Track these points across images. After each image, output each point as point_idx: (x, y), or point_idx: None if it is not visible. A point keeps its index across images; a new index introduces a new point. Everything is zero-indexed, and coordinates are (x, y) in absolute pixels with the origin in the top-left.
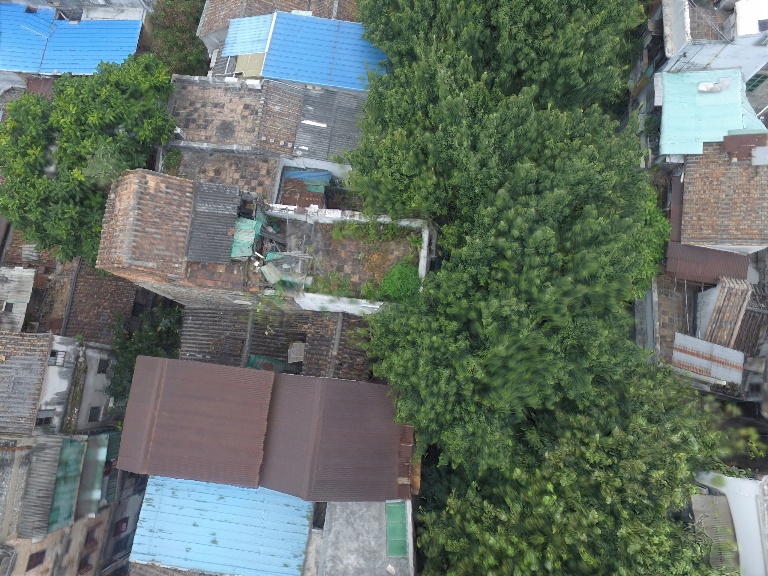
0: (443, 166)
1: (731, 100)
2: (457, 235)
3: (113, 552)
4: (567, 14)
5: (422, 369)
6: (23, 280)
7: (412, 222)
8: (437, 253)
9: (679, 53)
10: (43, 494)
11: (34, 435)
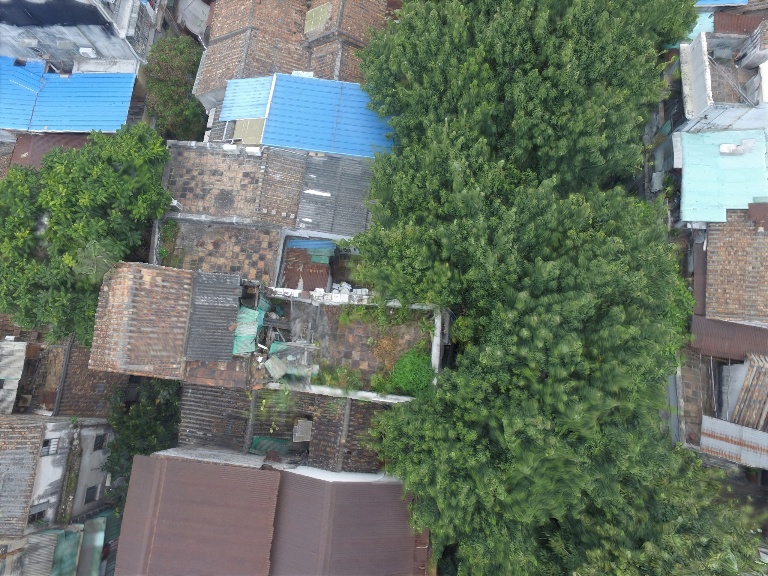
0: (457, 256)
1: (755, 164)
2: (473, 327)
3: None
4: (585, 88)
5: (440, 484)
6: (14, 354)
7: (424, 306)
8: (451, 340)
9: (700, 115)
10: None
11: (26, 534)
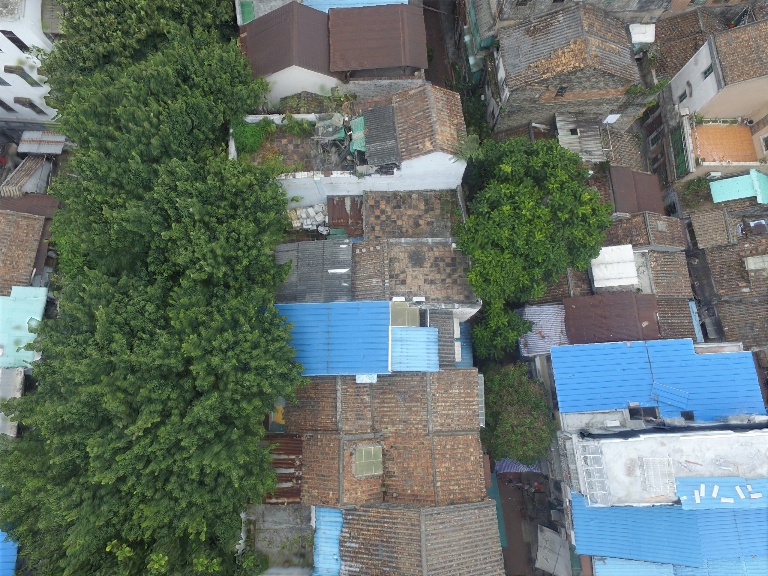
0: None
1: None
2: None
3: None
4: None
5: None
6: None
7: None
8: None
9: None
10: (480, 7)
11: None
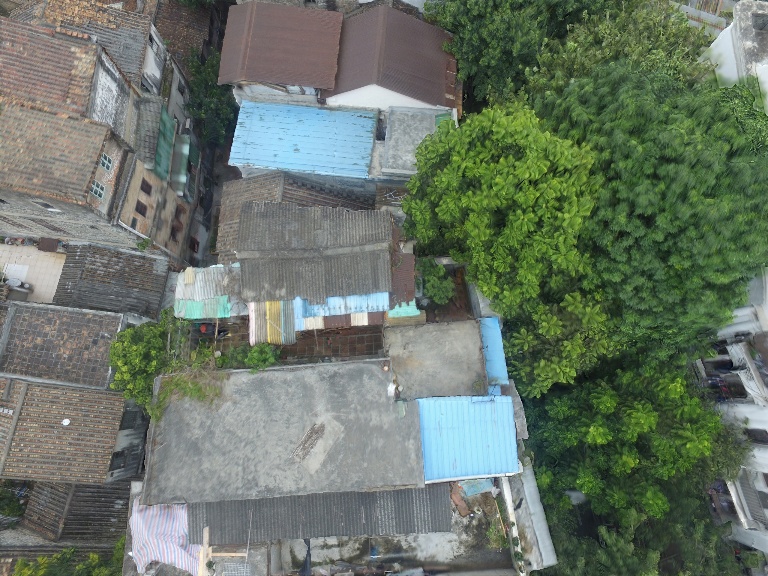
0: None
1: None
2: None
3: (189, 263)
4: None
5: None
6: None
7: None
8: None
9: None
10: (150, 134)
11: None
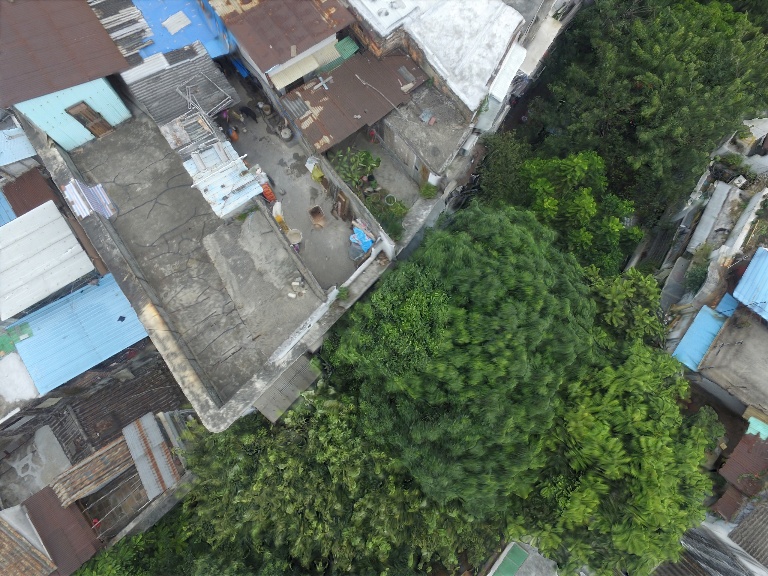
0: None
1: None
2: None
3: None
4: None
5: None
6: None
7: None
8: None
9: None
10: None
11: None
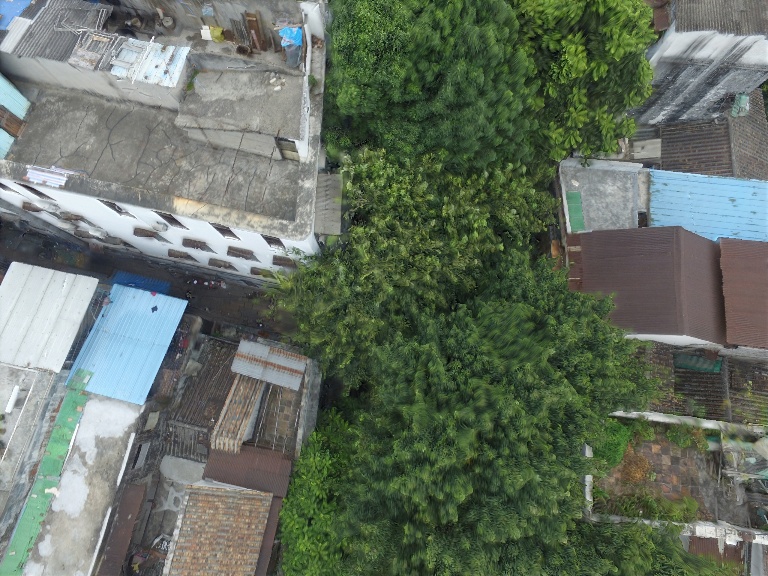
0: None
1: None
2: None
3: None
4: None
5: None
6: None
7: (606, 519)
8: None
9: None
10: None
11: None
